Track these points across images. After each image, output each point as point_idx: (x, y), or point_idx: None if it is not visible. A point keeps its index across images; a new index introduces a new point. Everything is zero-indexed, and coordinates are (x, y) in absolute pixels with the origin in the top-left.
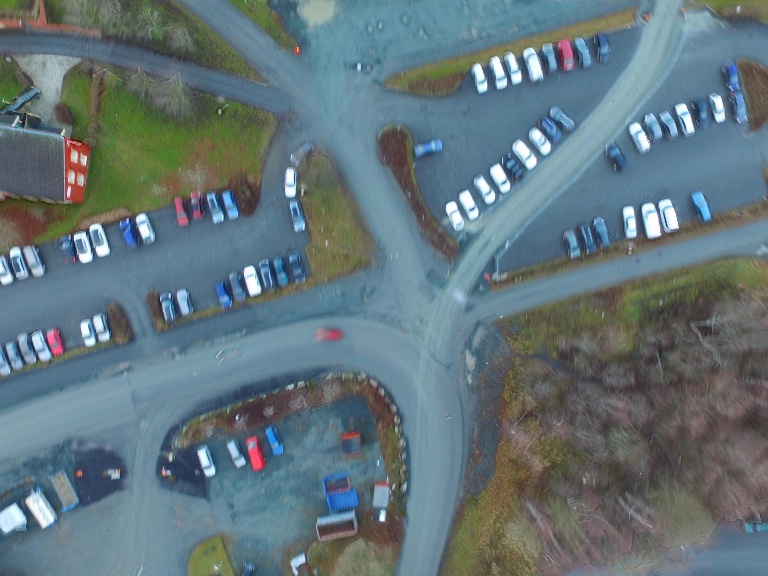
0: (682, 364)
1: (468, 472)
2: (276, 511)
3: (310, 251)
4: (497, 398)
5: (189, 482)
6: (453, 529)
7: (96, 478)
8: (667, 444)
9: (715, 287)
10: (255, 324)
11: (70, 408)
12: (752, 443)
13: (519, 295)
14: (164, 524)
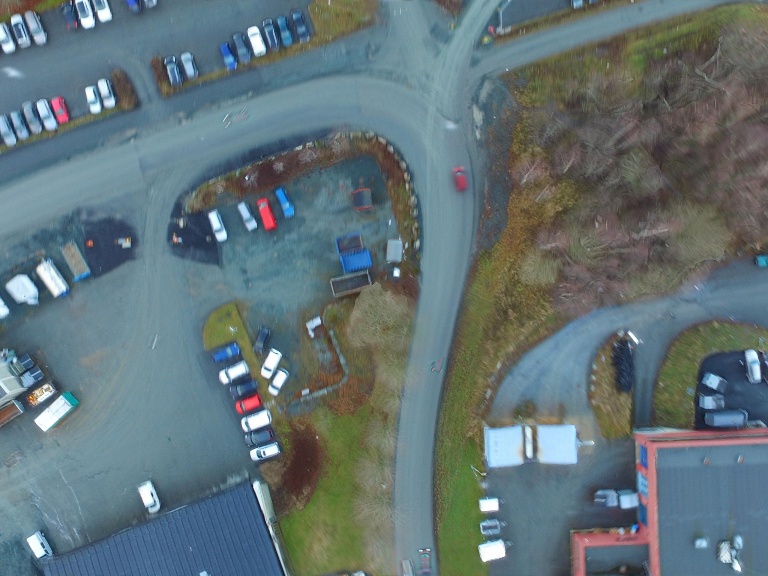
0: (689, 92)
1: (480, 228)
2: (289, 275)
3: (313, 10)
4: (506, 152)
5: (201, 249)
6: (468, 284)
7: (107, 247)
8: (677, 187)
9: (718, 33)
10: (261, 86)
11: (78, 178)
12: (764, 133)
13: (524, 47)
14: (177, 292)
